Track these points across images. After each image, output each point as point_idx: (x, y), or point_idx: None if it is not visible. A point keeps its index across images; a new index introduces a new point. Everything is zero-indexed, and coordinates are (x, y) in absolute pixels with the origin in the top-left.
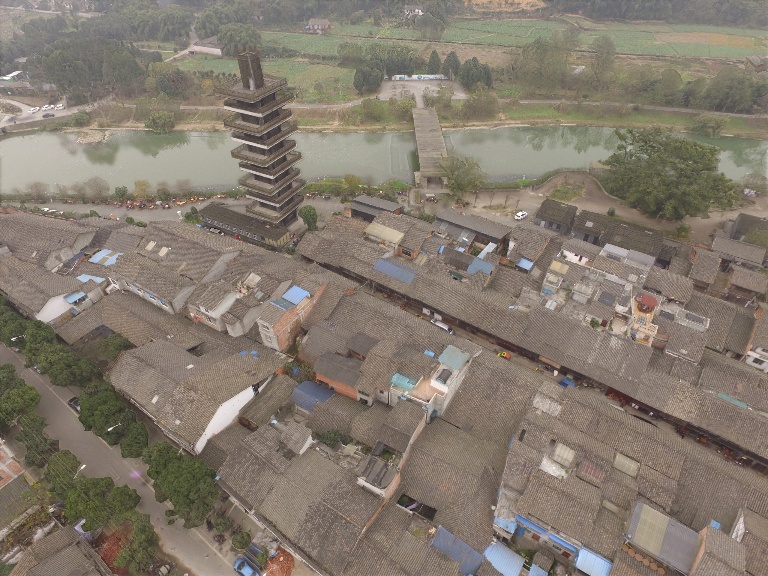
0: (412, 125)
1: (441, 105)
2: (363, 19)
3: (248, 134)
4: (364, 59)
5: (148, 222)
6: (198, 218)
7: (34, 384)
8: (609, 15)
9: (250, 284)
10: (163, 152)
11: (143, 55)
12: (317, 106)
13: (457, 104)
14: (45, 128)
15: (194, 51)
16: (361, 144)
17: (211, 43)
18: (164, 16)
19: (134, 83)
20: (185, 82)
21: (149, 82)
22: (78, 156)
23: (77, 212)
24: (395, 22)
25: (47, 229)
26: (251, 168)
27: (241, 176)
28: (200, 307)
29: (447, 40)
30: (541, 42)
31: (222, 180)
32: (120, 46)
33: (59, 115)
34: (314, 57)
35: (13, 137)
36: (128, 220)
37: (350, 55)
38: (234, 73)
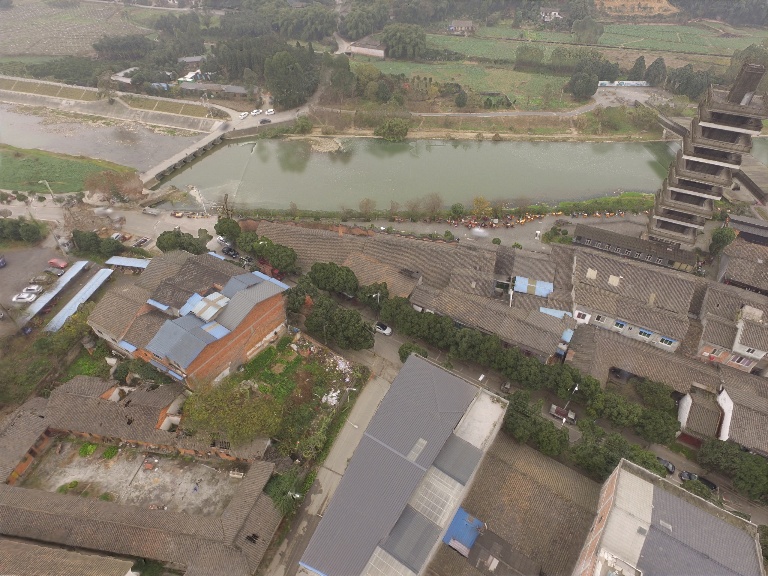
0: (654, 134)
1: (670, 113)
2: (497, 21)
3: (704, 152)
4: (541, 63)
5: (506, 243)
6: (557, 238)
7: (578, 438)
8: (745, 21)
9: (754, 318)
10: (419, 162)
11: (319, 56)
12: (546, 113)
13: (687, 113)
14: (265, 135)
15: (351, 52)
16: (621, 155)
17: (369, 44)
18: (312, 15)
19: (352, 87)
20: (389, 86)
21: (373, 86)
22: (331, 166)
23: (416, 232)
24: (537, 25)
25: (453, 254)
26: (689, 188)
27: (530, 190)
28: (740, 347)
29: (605, 44)
30: (758, 49)
31: (513, 194)
32: (295, 46)
33: (275, 121)
34: (484, 60)
35: (229, 144)
36: (498, 242)
37: (533, 59)
38: (430, 77)
